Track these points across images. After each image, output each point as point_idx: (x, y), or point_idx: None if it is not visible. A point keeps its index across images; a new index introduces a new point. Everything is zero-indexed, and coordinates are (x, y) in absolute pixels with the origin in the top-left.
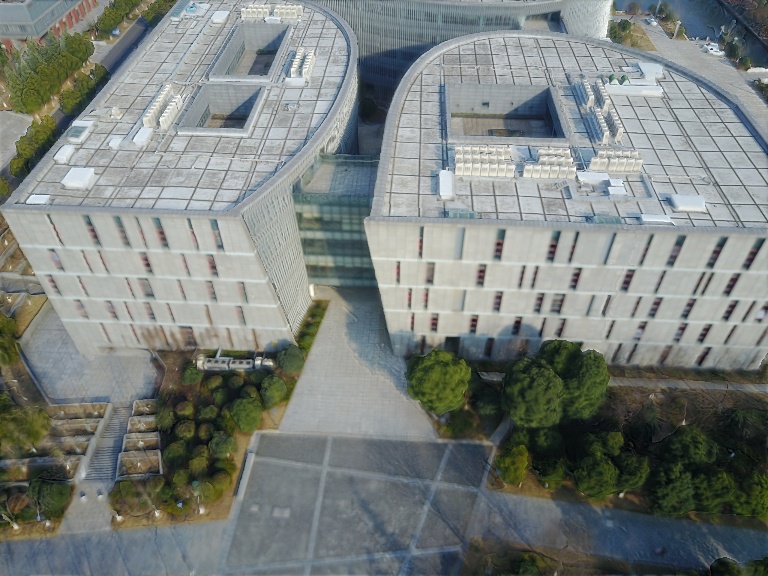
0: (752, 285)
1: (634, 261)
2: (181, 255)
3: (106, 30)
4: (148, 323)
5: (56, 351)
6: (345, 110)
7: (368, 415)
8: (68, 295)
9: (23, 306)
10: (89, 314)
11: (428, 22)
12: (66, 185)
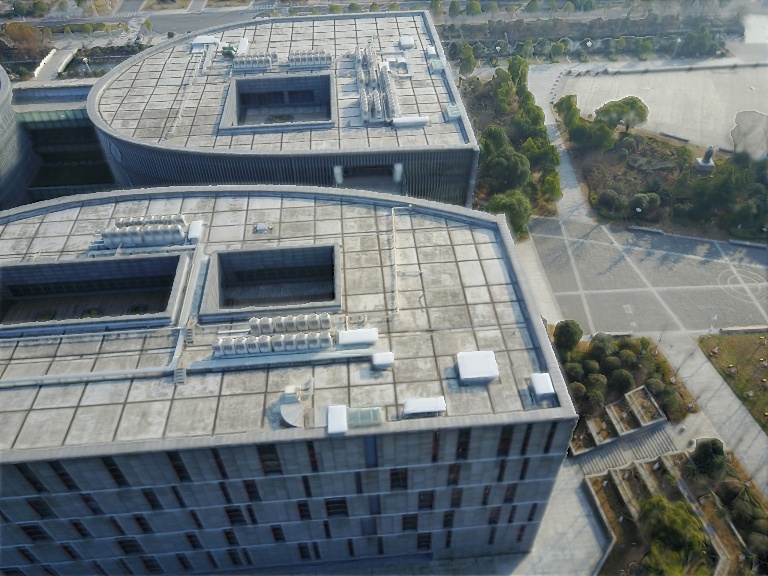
0: None
1: None
2: None
3: None
4: None
5: None
6: None
7: None
8: None
9: None
10: None
11: None
12: None
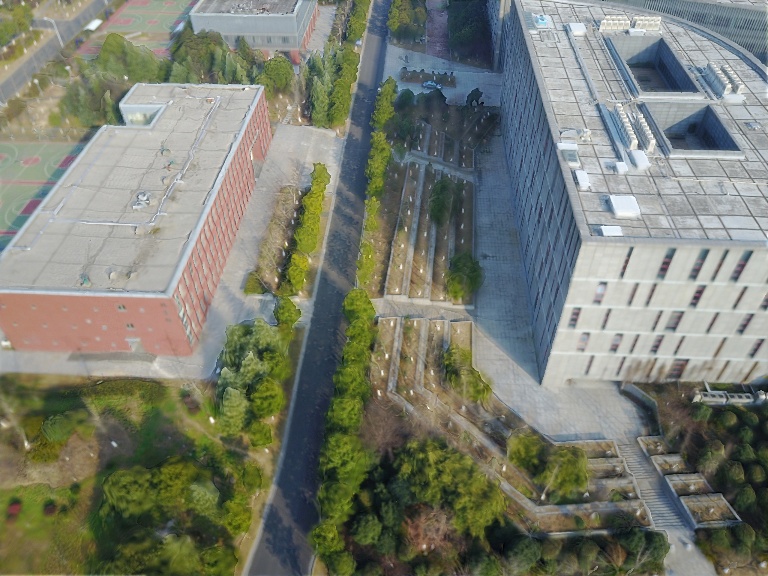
0: None
1: None
2: (743, 288)
3: (354, 40)
4: (645, 356)
5: (513, 383)
6: None
7: None
8: (581, 328)
9: (451, 334)
10: (588, 347)
11: (766, 32)
12: (618, 214)
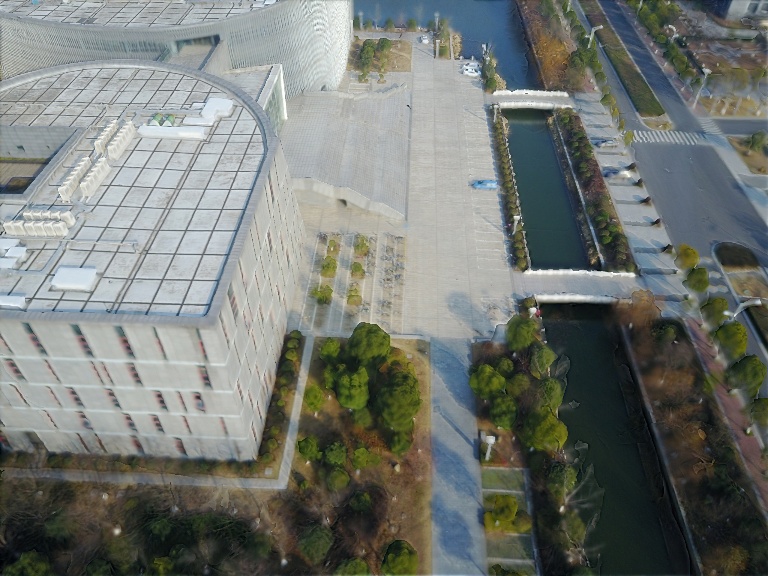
0: (156, 375)
1: (0, 349)
2: None
3: None
4: None
5: None
6: None
7: None
8: None
9: None
10: None
11: (73, 48)
12: None
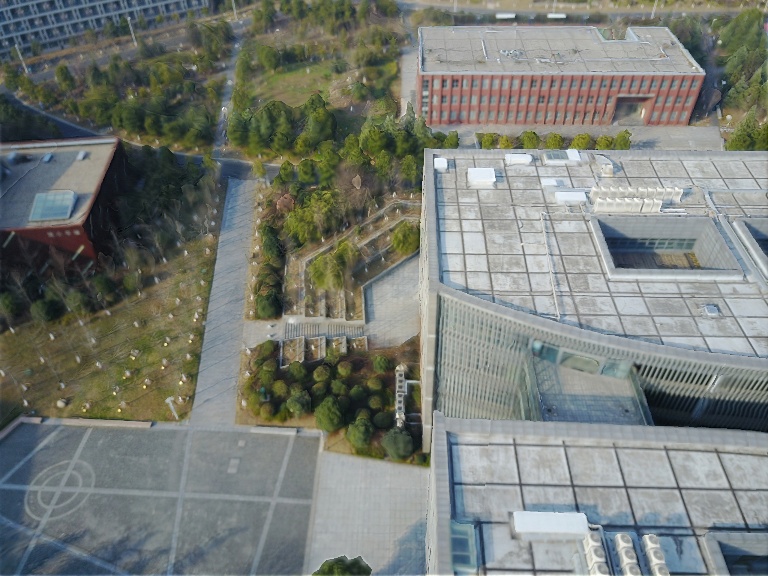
0: None
1: None
2: None
3: None
4: None
5: None
6: (767, 384)
7: (337, 540)
8: None
9: None
10: None
11: None
12: None
